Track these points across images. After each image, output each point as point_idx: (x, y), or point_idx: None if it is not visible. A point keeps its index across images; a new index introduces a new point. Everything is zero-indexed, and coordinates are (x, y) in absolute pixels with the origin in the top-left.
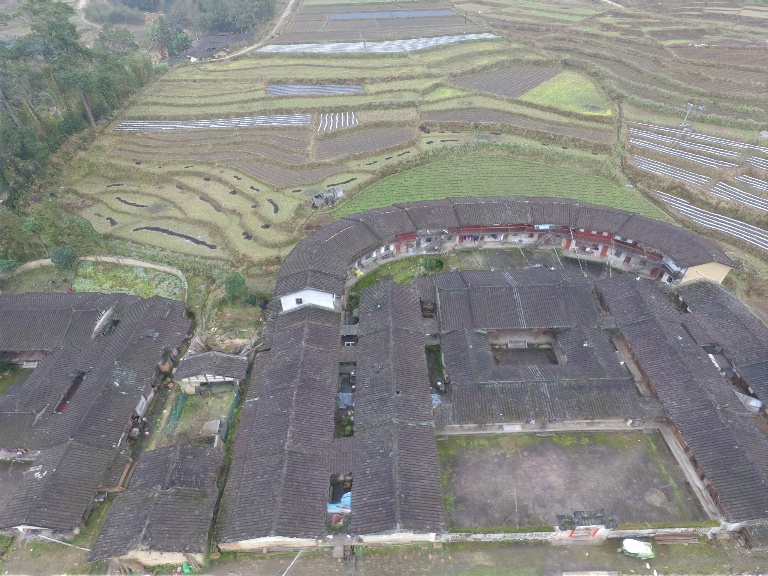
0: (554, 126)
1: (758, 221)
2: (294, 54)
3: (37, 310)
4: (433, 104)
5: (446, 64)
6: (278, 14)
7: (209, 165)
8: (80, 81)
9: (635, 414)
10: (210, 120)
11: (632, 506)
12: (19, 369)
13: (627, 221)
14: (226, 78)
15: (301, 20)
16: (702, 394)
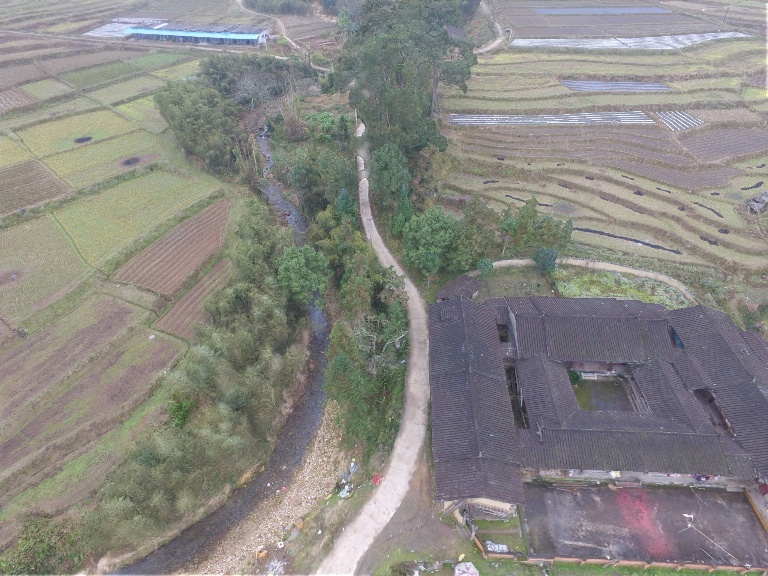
0: None
1: None
2: (556, 49)
3: (599, 317)
4: (761, 105)
5: (728, 63)
6: (478, 8)
7: (581, 163)
8: (462, 71)
9: None
10: (541, 115)
11: None
12: (580, 381)
13: None
14: (511, 72)
15: (515, 14)
16: None
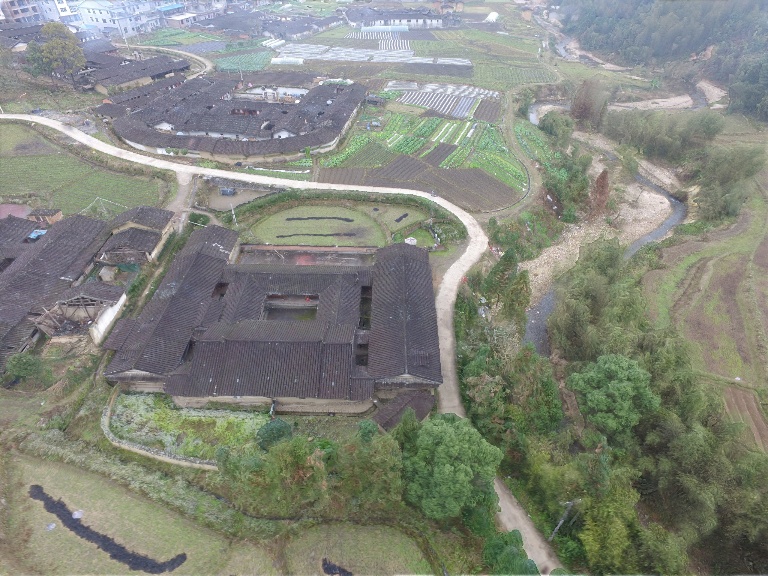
0: None
1: None
2: None
3: (266, 340)
4: None
5: None
6: None
7: None
8: None
9: None
10: None
11: None
12: None
13: None
14: None
15: None
16: None
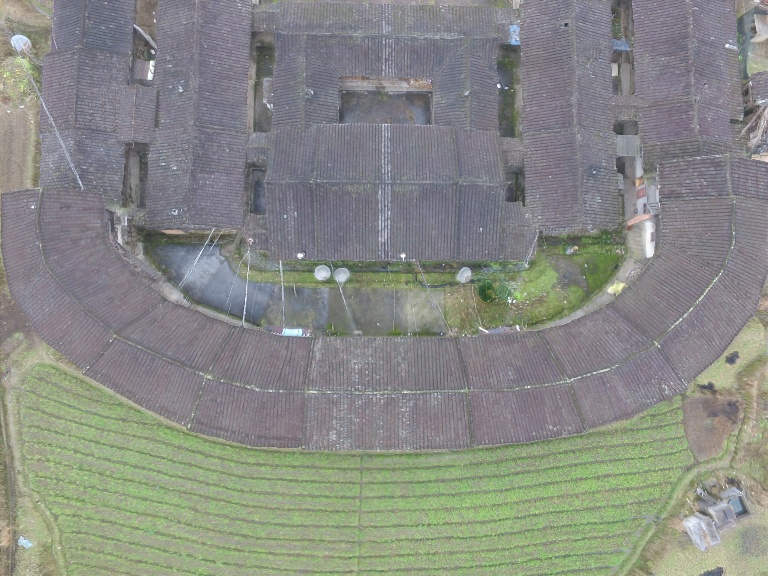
0: None
1: None
2: None
3: None
4: None
5: None
6: None
7: None
8: None
9: (290, 3)
10: None
11: None
12: None
13: (130, 324)
14: None
15: None
16: (205, 3)
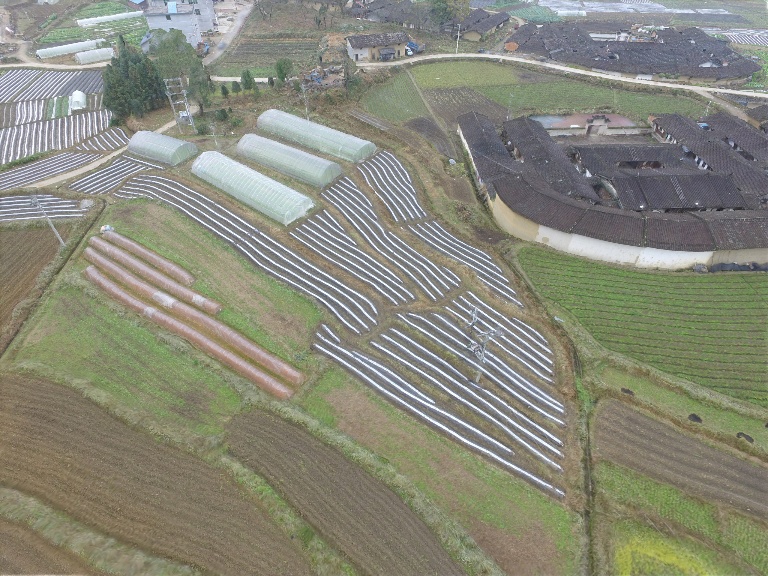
0: (764, 506)
1: (425, 245)
2: None
3: None
4: None
5: None
6: None
7: None
8: None
9: None
10: None
11: (571, 140)
12: None
13: None
14: None
15: None
16: (543, 141)
